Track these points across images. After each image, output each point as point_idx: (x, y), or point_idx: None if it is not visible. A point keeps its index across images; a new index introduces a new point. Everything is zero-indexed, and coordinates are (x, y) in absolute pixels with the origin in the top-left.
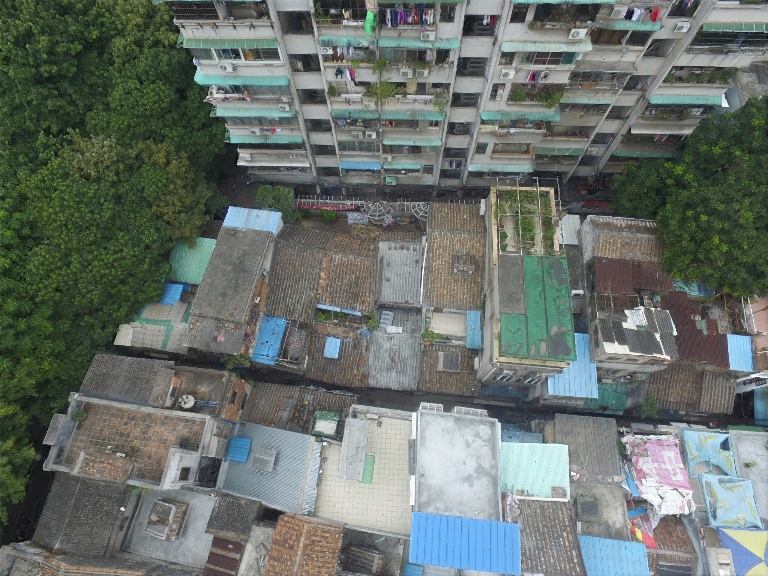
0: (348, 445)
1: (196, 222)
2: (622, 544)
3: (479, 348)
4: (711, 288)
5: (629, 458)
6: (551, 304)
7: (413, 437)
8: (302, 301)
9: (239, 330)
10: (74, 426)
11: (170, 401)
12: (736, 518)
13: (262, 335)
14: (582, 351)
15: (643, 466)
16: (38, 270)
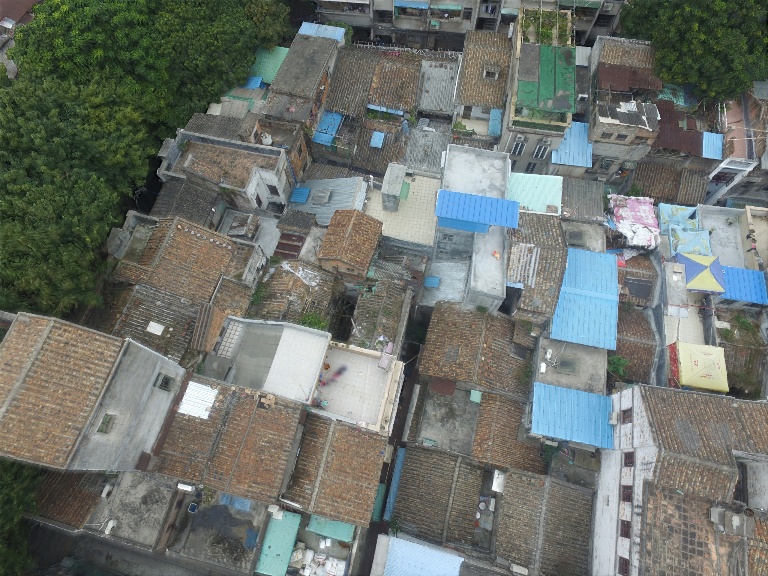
0: (390, 175)
1: (277, 27)
2: (598, 254)
3: (498, 135)
4: (695, 102)
5: (612, 210)
6: (560, 77)
7: (442, 166)
8: (356, 100)
9: (307, 104)
10: (178, 154)
11: (253, 140)
12: (693, 250)
13: (322, 124)
14: (582, 135)
15: (622, 213)
16: (162, 28)
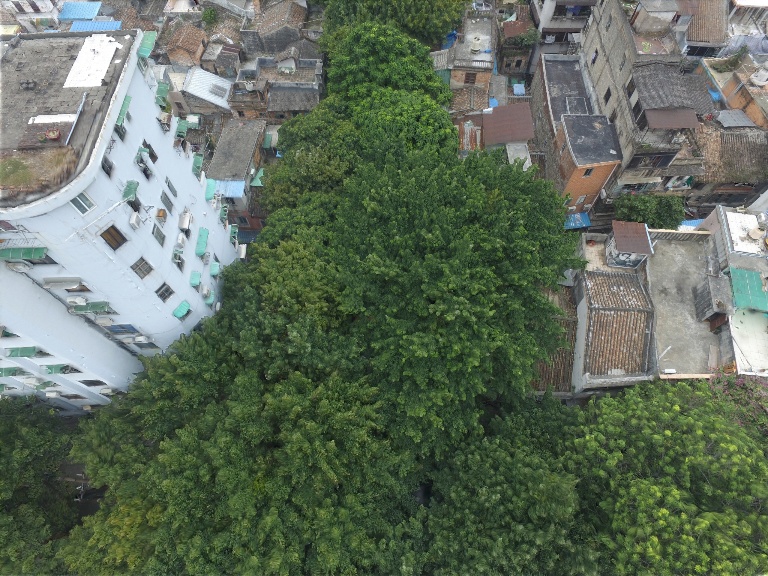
0: None
1: (262, 177)
2: None
3: None
4: None
5: None
6: None
7: None
8: None
9: None
10: None
11: None
12: None
13: None
14: None
15: None
16: None
